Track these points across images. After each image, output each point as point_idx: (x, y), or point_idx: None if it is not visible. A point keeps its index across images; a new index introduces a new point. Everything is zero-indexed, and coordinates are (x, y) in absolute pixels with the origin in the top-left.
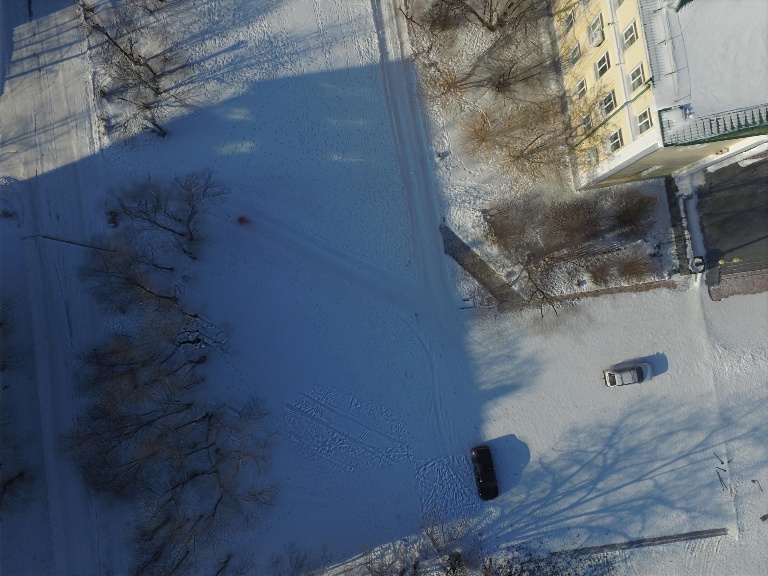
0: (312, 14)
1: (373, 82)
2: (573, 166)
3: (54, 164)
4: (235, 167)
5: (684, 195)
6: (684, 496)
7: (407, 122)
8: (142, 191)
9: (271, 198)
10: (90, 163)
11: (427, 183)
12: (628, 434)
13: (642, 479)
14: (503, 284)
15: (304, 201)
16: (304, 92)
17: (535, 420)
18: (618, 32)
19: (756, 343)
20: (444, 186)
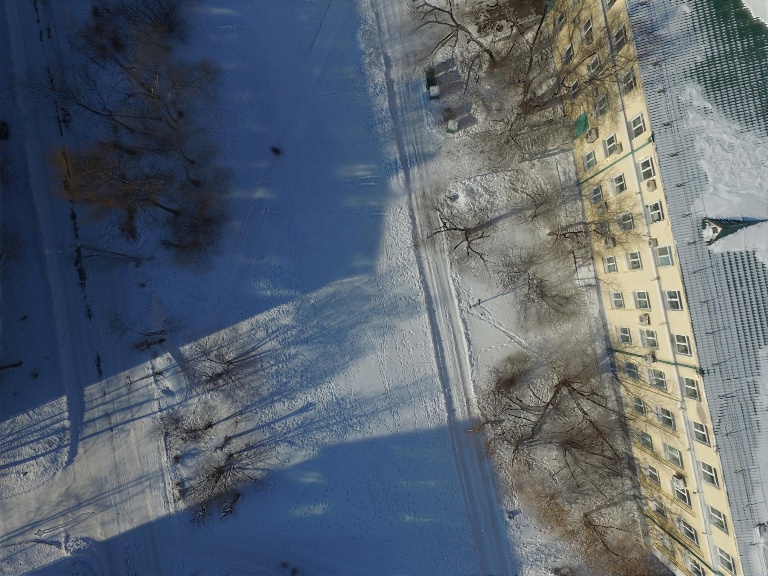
0: (379, 375)
1: (441, 443)
2: (643, 526)
3: (130, 523)
4: (308, 527)
5: None
6: None
7: (476, 480)
8: (218, 552)
9: (345, 560)
10: (165, 522)
11: (498, 541)
12: None
13: None
14: None
15: (378, 563)
16: (374, 453)
17: None
18: (704, 503)
19: None
20: (515, 544)
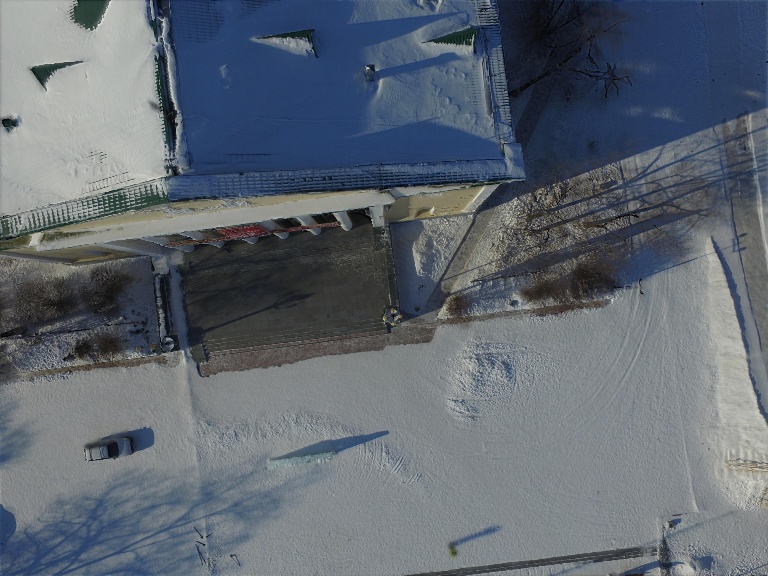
0: None
1: None
2: None
3: None
4: None
5: (160, 274)
6: (163, 569)
7: None
8: None
9: None
10: None
11: None
12: (112, 507)
13: (123, 551)
14: (1, 356)
15: None
16: None
17: (23, 491)
18: None
19: (241, 420)
20: None
